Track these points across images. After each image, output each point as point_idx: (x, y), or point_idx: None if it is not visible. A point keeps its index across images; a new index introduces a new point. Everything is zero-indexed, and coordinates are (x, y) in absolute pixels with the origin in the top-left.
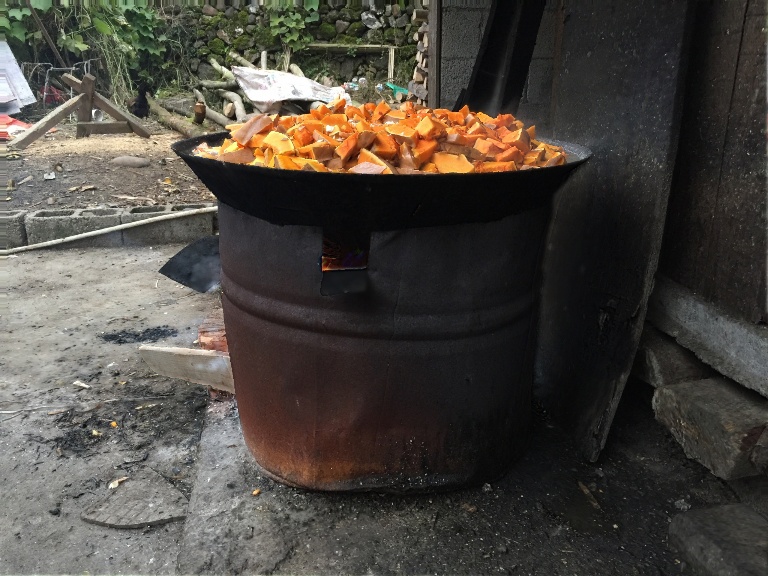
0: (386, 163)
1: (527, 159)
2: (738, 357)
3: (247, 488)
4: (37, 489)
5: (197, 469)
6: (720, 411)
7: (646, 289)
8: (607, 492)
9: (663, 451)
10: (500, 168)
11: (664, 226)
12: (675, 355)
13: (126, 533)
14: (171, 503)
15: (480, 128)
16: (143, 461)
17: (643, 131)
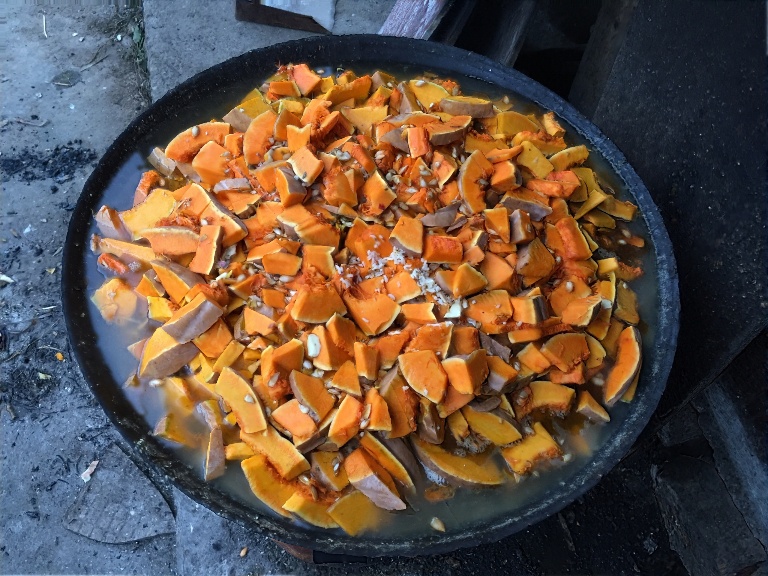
0: (402, 456)
1: (591, 350)
2: (758, 502)
3: (234, 547)
4: (3, 476)
5: (175, 498)
6: (719, 541)
7: (686, 400)
8: (584, 526)
9: (645, 456)
10: (555, 404)
11: (735, 357)
12: (690, 417)
13: (115, 549)
14: (153, 511)
15: (536, 323)
16: (108, 427)
17: (759, 228)
